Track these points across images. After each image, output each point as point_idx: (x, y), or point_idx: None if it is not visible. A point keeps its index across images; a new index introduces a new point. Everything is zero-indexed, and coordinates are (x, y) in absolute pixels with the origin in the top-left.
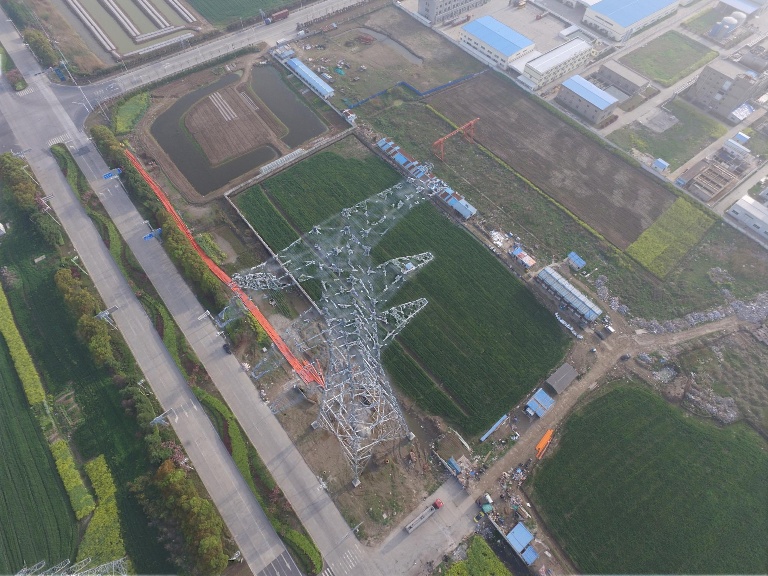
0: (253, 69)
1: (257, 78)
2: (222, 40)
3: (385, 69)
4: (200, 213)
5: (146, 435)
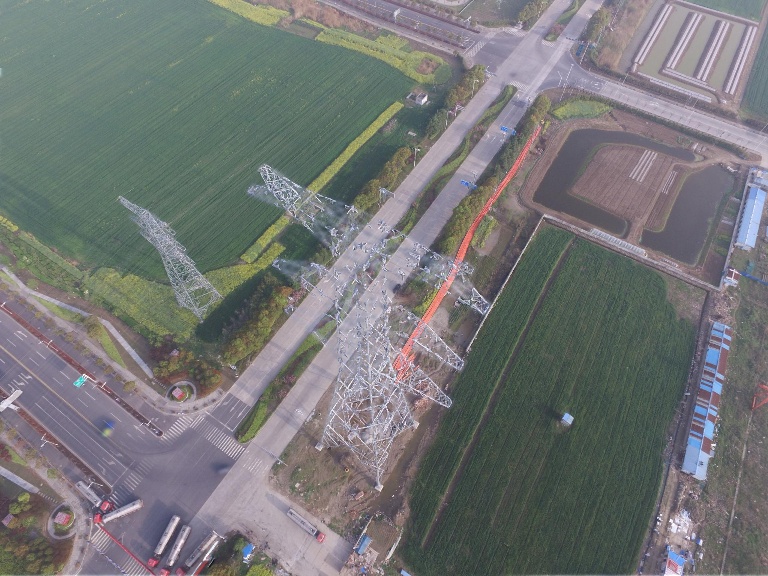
0: (714, 166)
1: (706, 175)
2: (727, 124)
3: None
4: (514, 207)
5: (307, 267)
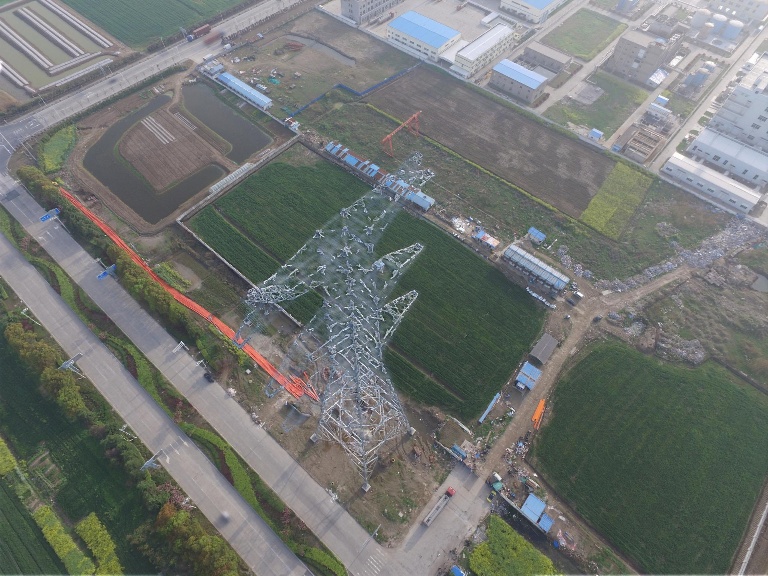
0: (183, 88)
1: (189, 97)
2: (144, 62)
3: (319, 73)
4: (154, 243)
5: (138, 482)
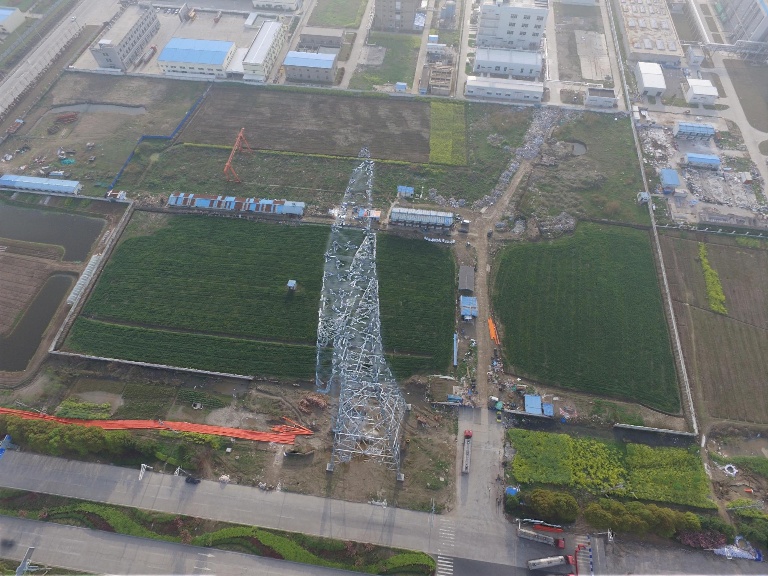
0: None
1: None
2: None
3: (114, 134)
4: (37, 388)
5: None
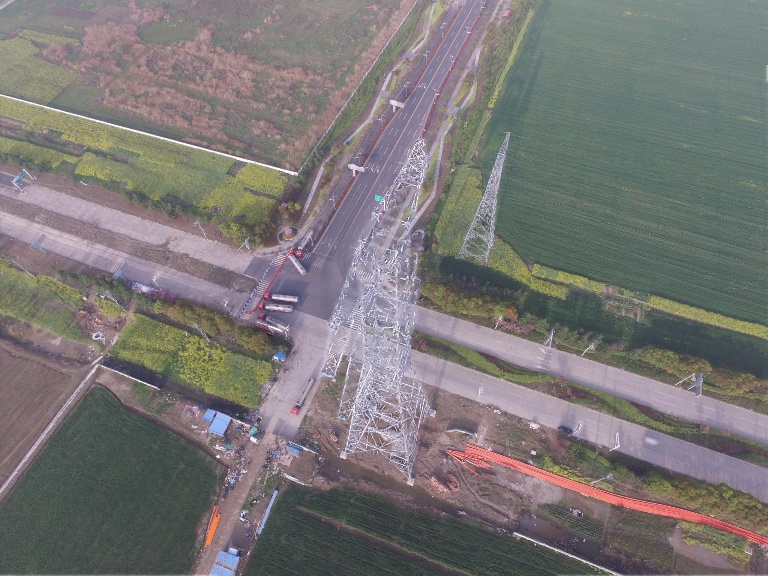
0: None
1: None
2: None
3: None
4: None
5: None
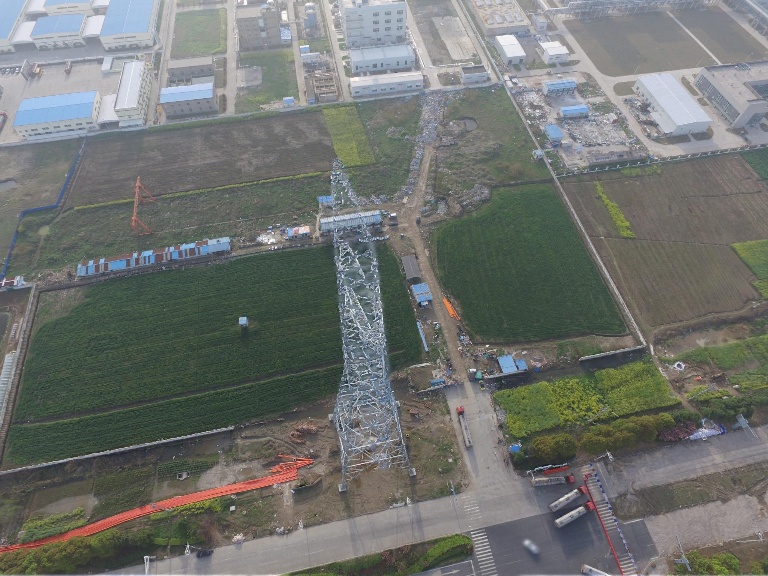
0: None
1: None
2: None
3: None
4: None
5: None
